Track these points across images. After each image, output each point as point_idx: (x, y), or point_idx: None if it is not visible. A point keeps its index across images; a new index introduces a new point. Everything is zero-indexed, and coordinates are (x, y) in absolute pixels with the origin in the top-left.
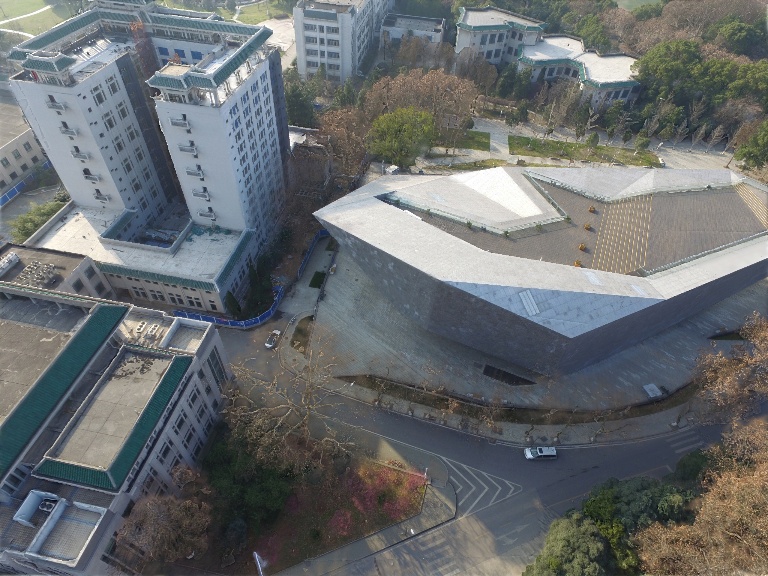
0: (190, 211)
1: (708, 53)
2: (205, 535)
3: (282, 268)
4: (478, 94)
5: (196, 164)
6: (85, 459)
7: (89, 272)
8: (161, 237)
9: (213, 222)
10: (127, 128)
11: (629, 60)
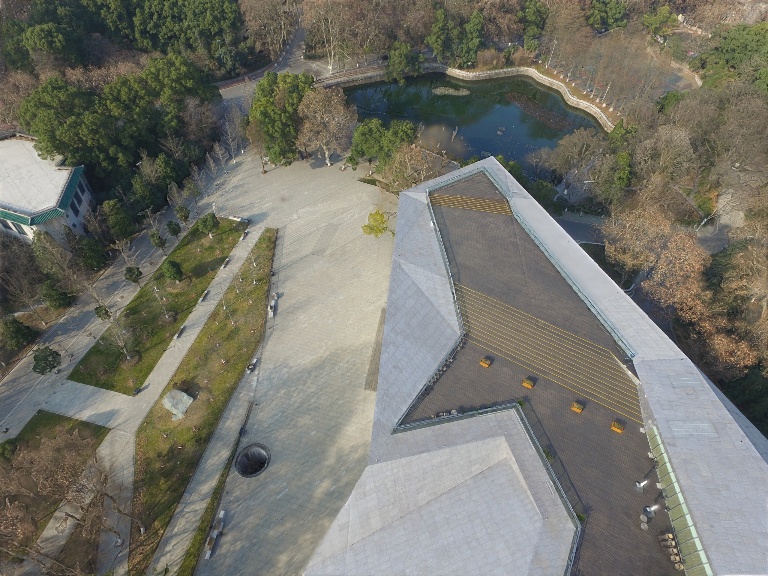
0: None
1: (87, 82)
2: None
3: None
4: None
5: None
6: None
7: None
8: None
9: None
10: None
11: (2, 147)
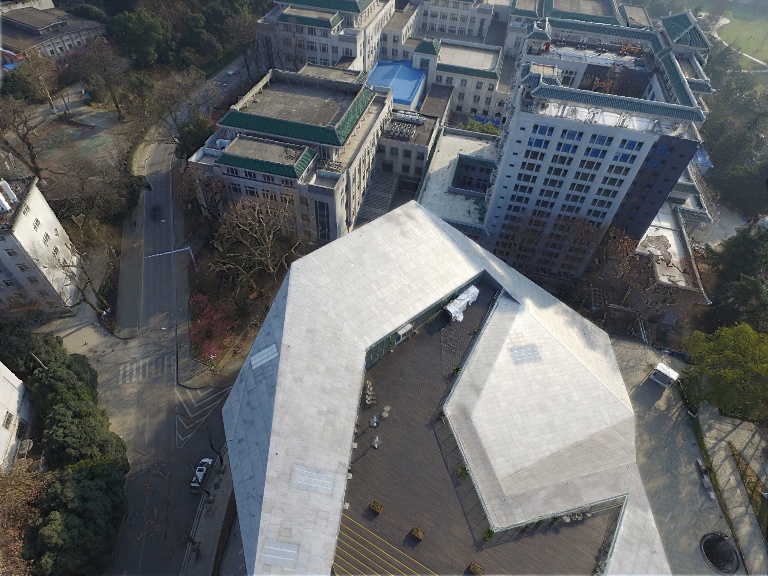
0: None
1: None
2: (182, 199)
3: None
4: None
5: None
6: (234, 147)
7: (421, 156)
8: None
9: None
10: None
11: None
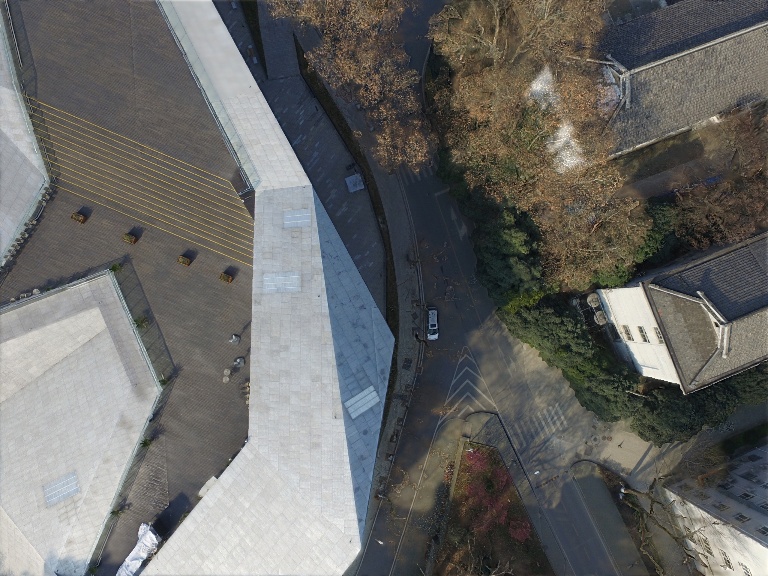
0: None
1: None
2: None
3: None
4: None
5: None
6: None
7: None
8: None
9: None
10: None
11: None
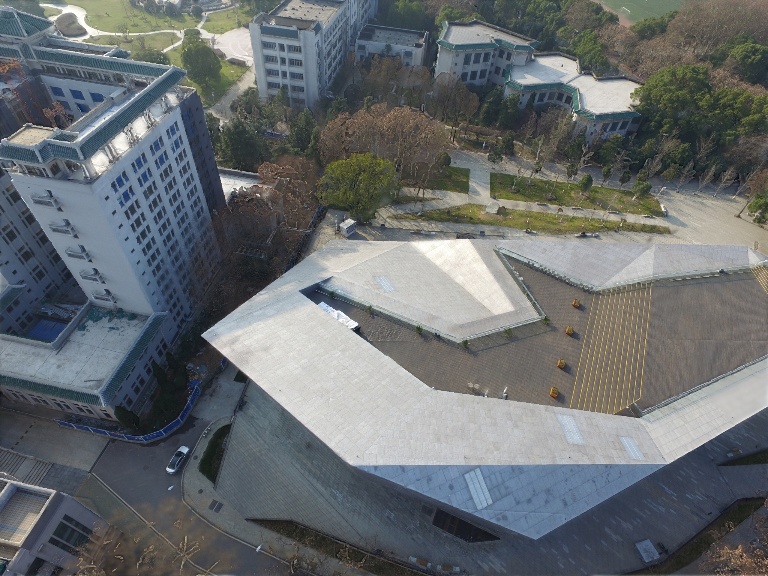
0: (85, 291)
1: (718, 81)
2: None
3: (204, 354)
4: (460, 120)
5: (78, 244)
6: None
7: None
8: (59, 314)
9: (114, 304)
10: (6, 189)
11: (629, 85)
